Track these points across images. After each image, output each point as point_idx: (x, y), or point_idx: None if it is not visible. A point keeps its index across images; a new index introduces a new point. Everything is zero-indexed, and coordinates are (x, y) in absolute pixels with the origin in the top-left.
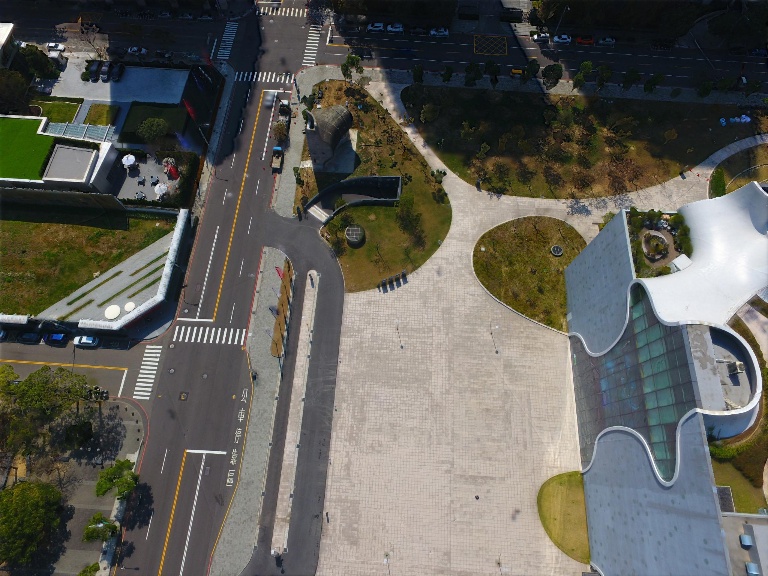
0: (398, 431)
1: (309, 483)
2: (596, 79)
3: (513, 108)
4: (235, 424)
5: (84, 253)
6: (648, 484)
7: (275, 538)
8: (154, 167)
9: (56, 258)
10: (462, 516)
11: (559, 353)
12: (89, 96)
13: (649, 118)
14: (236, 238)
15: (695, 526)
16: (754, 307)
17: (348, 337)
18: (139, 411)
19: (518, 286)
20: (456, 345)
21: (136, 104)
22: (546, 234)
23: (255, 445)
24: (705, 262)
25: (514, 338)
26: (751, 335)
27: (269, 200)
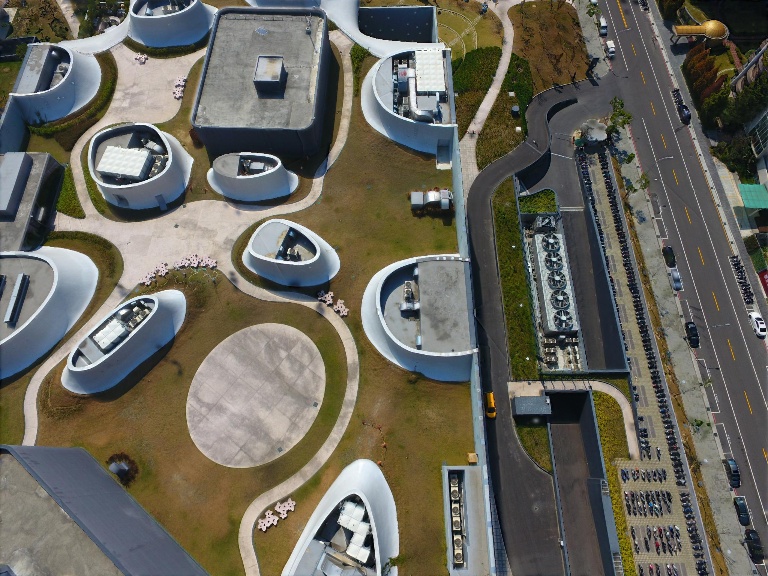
0: None
1: None
2: None
3: None
4: None
5: None
6: None
7: None
8: None
9: None
10: None
11: None
12: None
13: None
14: None
15: None
16: (125, 45)
17: None
18: None
19: None
20: None
21: None
22: None
23: None
24: None
25: None
26: None
27: None
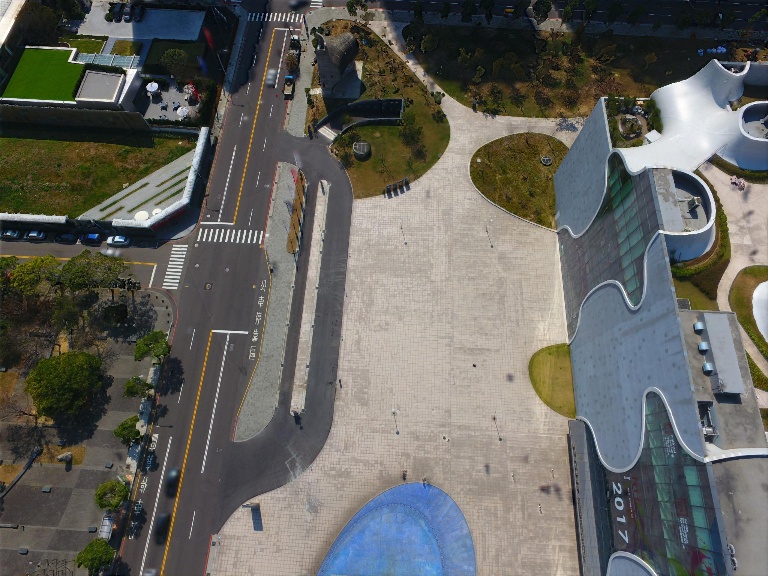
0: (403, 312)
1: (323, 356)
2: (583, 13)
3: (506, 40)
4: (255, 309)
5: (114, 167)
6: (622, 318)
7: (294, 401)
8: (175, 95)
9: (89, 171)
10: (461, 381)
11: (548, 247)
12: (113, 34)
13: (631, 45)
14: (252, 155)
15: (658, 328)
16: (713, 164)
17: (357, 236)
18: (168, 299)
19: (511, 191)
20: (455, 241)
21: (157, 41)
22: (537, 147)
23: (274, 326)
24: (673, 133)
25: (507, 235)
26: (710, 184)
27: (282, 122)
